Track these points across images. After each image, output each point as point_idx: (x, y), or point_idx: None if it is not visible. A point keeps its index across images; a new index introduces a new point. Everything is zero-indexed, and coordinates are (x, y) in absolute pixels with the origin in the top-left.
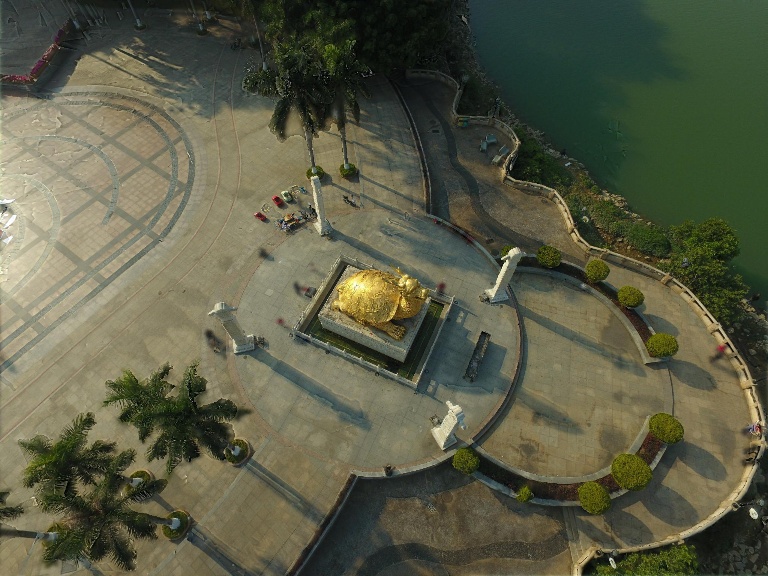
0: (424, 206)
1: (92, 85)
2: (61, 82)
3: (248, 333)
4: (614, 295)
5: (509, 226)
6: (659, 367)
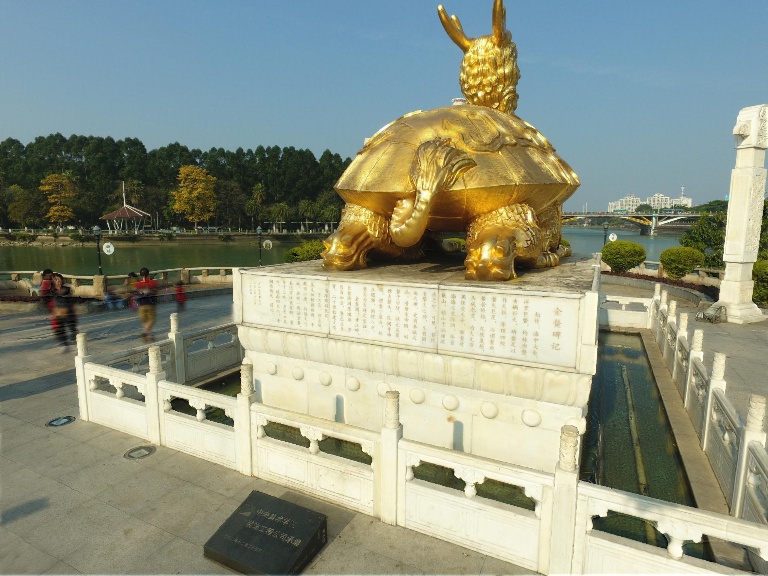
0: (60, 307)
1: None
2: None
3: None
4: None
5: None
6: None
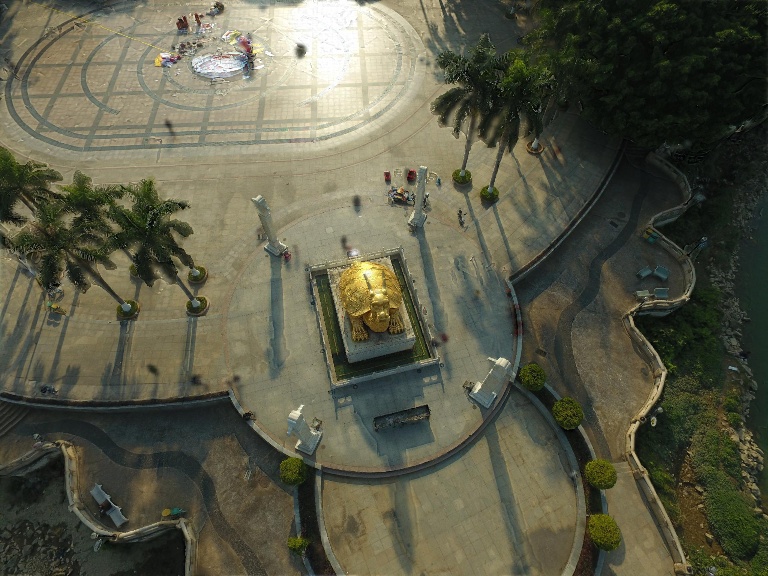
0: (515, 271)
1: (394, 11)
2: None
3: (286, 243)
4: None
5: (577, 358)
6: None
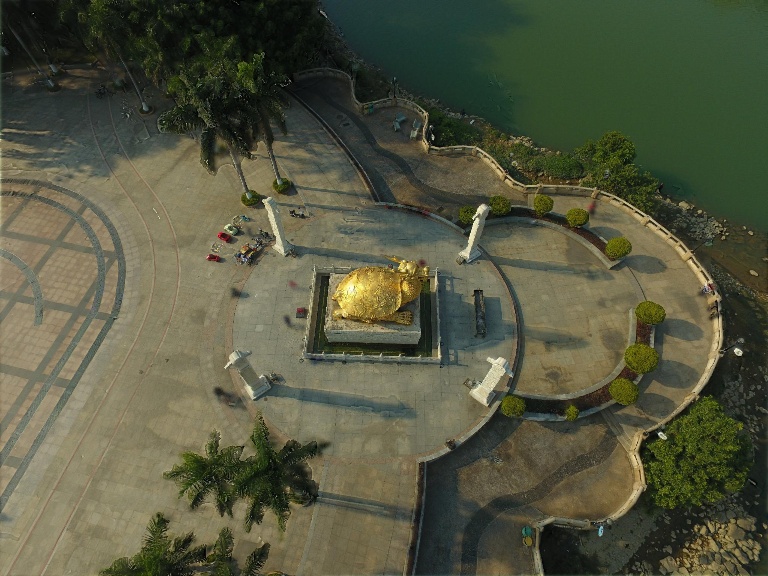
0: (370, 196)
1: None
2: None
3: None
4: (562, 221)
5: (451, 191)
6: (620, 267)
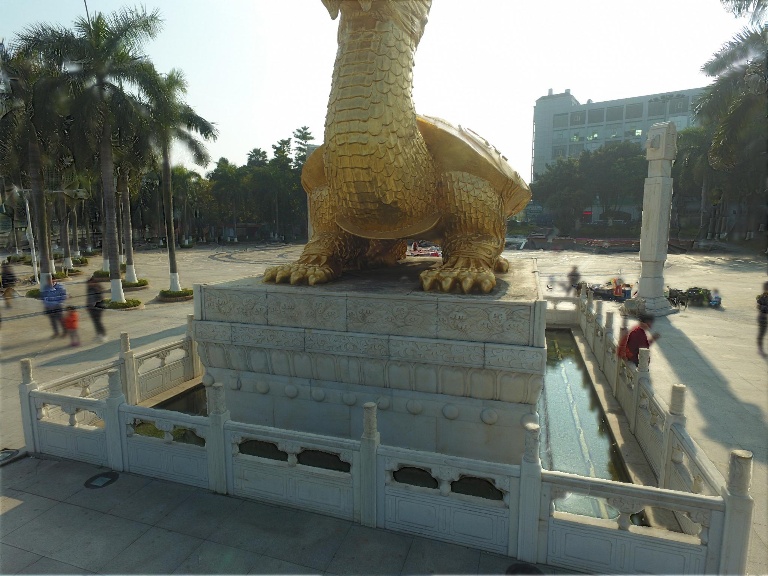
0: None
1: None
2: (622, 251)
3: None
4: None
5: None
6: None
